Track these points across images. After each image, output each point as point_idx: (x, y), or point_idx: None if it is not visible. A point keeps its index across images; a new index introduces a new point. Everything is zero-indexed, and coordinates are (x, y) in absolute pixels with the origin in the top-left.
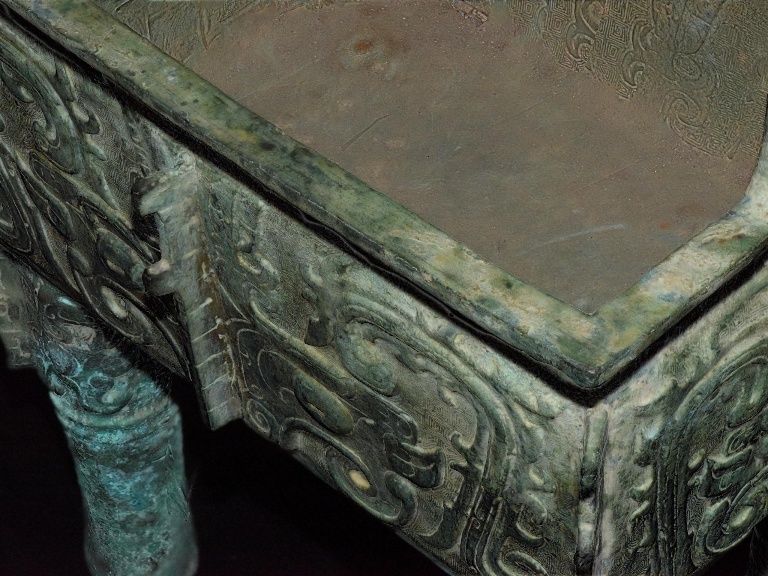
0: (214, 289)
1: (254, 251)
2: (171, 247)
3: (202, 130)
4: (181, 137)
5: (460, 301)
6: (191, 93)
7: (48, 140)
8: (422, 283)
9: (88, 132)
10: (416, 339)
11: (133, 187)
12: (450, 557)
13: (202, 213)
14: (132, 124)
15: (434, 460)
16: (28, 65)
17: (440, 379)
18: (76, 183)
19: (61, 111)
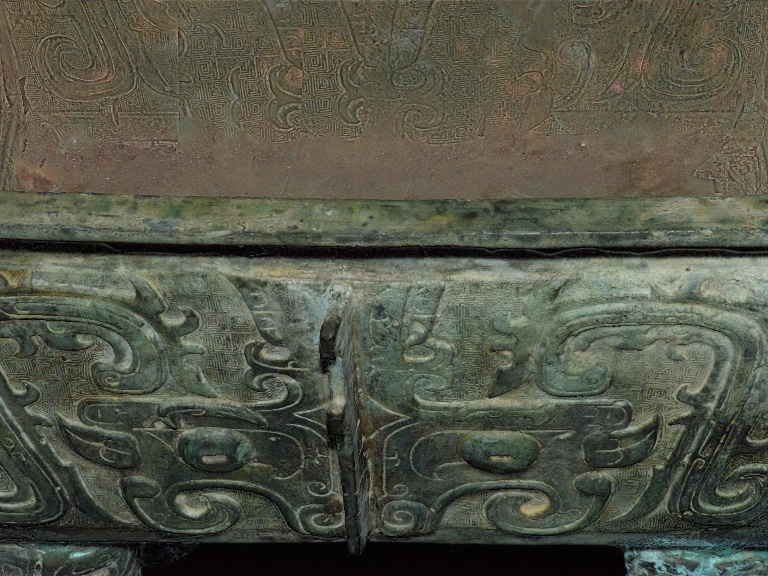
0: (361, 409)
1: (427, 338)
2: (345, 380)
3: (405, 234)
4: (320, 274)
5: (749, 234)
6: (360, 214)
7: (121, 372)
8: (701, 241)
9: (184, 334)
10: (654, 313)
11: (323, 334)
12: (650, 521)
13: (360, 334)
14: (256, 292)
15: (654, 428)
16: (96, 305)
17: (674, 340)
18: (154, 400)
19: (144, 331)
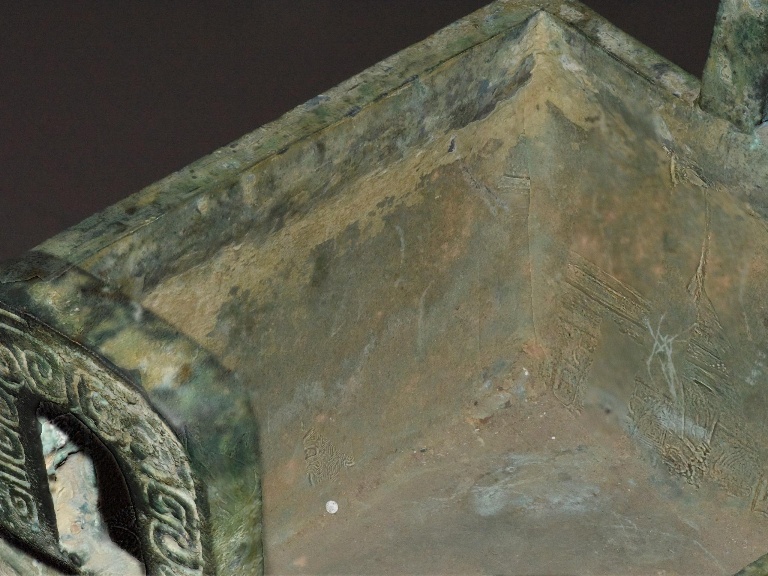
0: None
1: None
2: None
3: None
4: None
5: None
6: (205, 175)
7: None
8: None
9: None
10: None
11: None
12: None
13: None
14: None
15: None
16: None
17: None
18: None
19: None
